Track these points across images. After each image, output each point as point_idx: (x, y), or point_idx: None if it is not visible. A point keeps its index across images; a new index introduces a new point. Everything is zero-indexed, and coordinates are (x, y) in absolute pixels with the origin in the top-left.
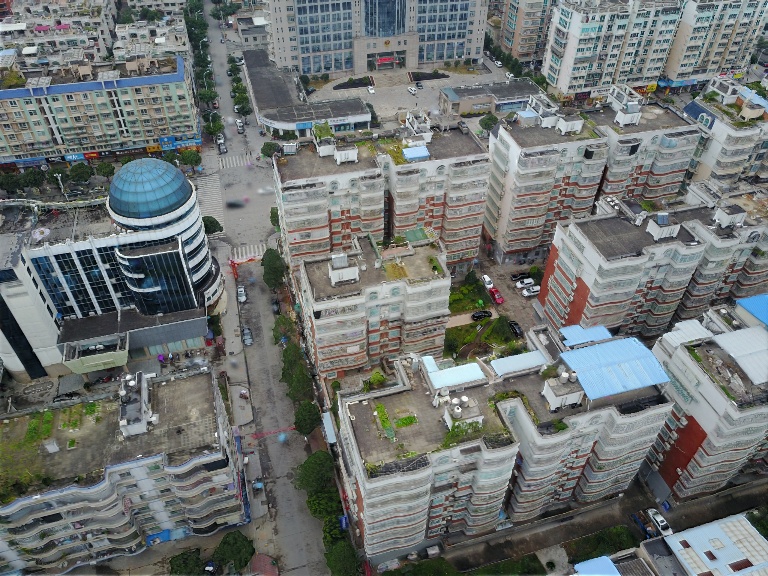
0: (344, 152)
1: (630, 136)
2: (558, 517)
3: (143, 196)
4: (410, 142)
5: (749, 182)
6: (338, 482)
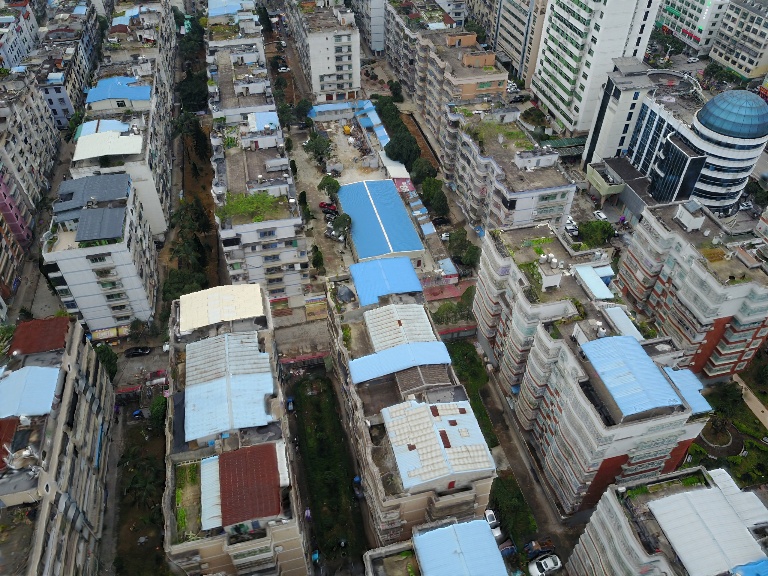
0: None
1: None
2: None
3: (715, 109)
4: None
5: None
6: None
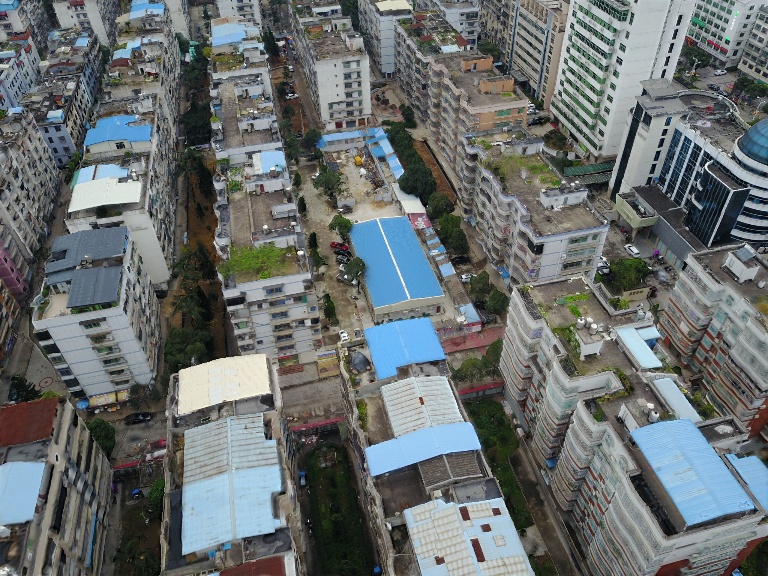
0: None
1: None
2: (570, 540)
3: (759, 137)
4: None
5: None
6: None
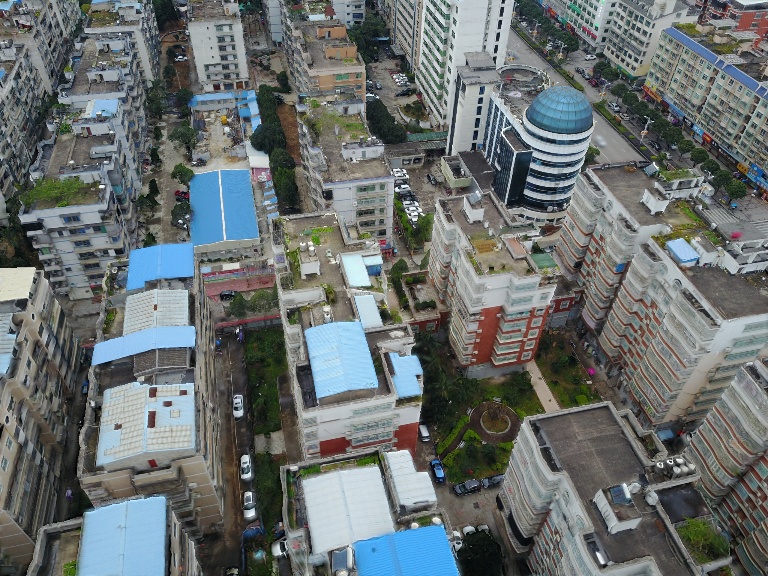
0: (649, 194)
1: None
2: None
3: None
4: (695, 240)
5: None
6: None
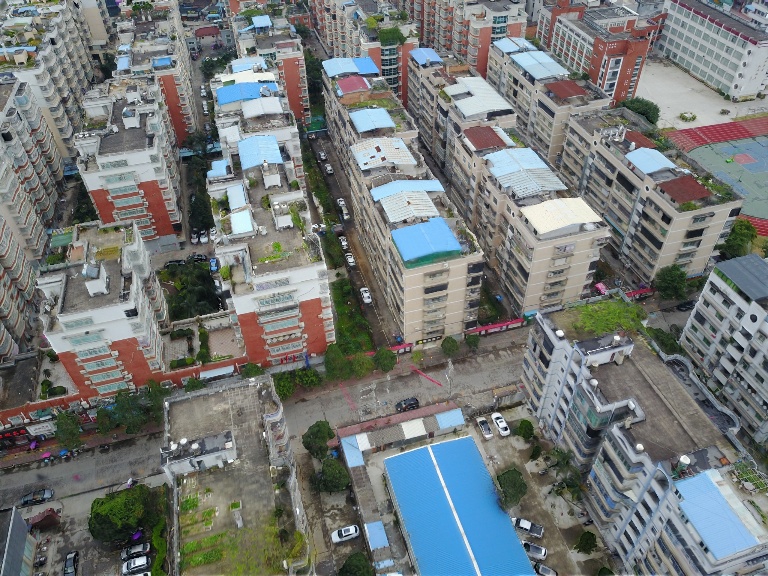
0: None
1: (6, 109)
2: None
3: None
4: None
5: (97, 83)
6: (269, 369)
